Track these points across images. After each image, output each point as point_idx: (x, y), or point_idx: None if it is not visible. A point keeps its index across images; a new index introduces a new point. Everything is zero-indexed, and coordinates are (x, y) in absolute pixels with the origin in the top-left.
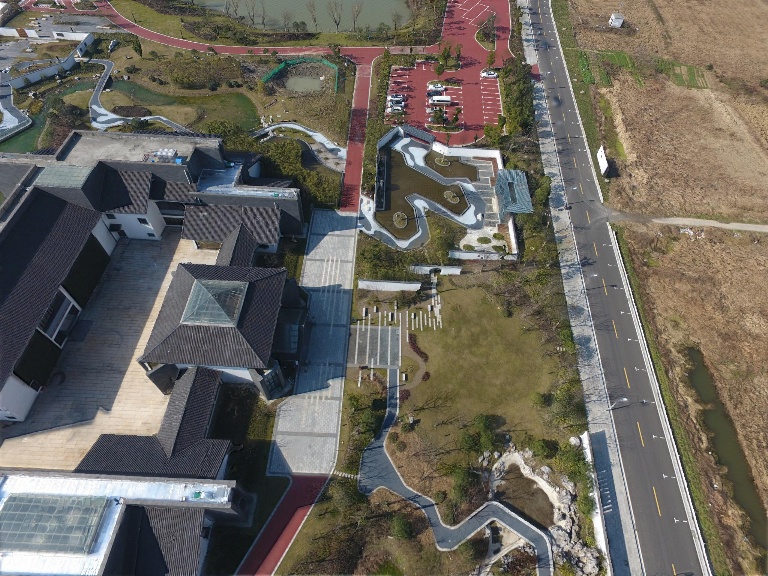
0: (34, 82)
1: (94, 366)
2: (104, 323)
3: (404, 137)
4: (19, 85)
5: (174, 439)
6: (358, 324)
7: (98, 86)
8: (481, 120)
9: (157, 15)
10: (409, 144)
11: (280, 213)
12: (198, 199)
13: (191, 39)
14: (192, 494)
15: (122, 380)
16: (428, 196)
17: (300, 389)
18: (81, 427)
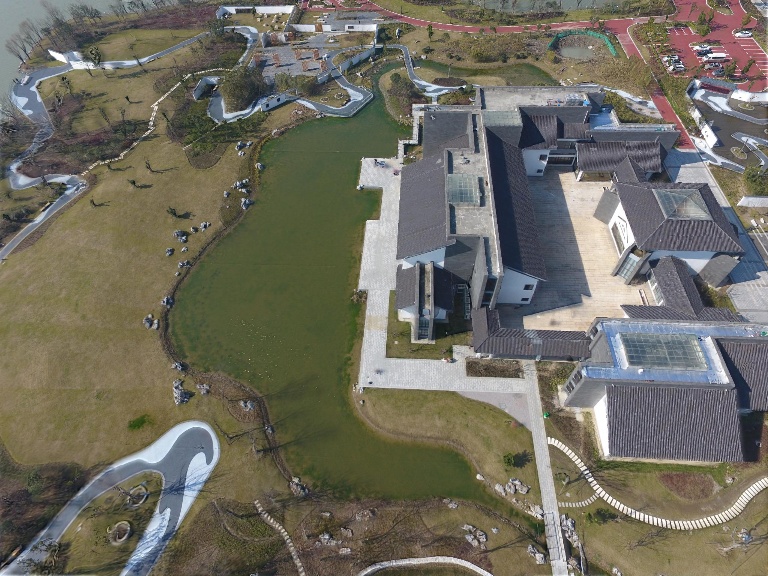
0: (354, 65)
1: (555, 266)
2: (541, 236)
3: (698, 89)
4: (345, 68)
5: (690, 305)
6: (754, 232)
7: (407, 65)
8: (759, 72)
9: (416, 7)
10: (706, 94)
11: (659, 145)
12: (591, 136)
13: (458, 23)
14: (759, 332)
15: (585, 275)
16: (751, 134)
17: (737, 279)
18: (577, 308)
